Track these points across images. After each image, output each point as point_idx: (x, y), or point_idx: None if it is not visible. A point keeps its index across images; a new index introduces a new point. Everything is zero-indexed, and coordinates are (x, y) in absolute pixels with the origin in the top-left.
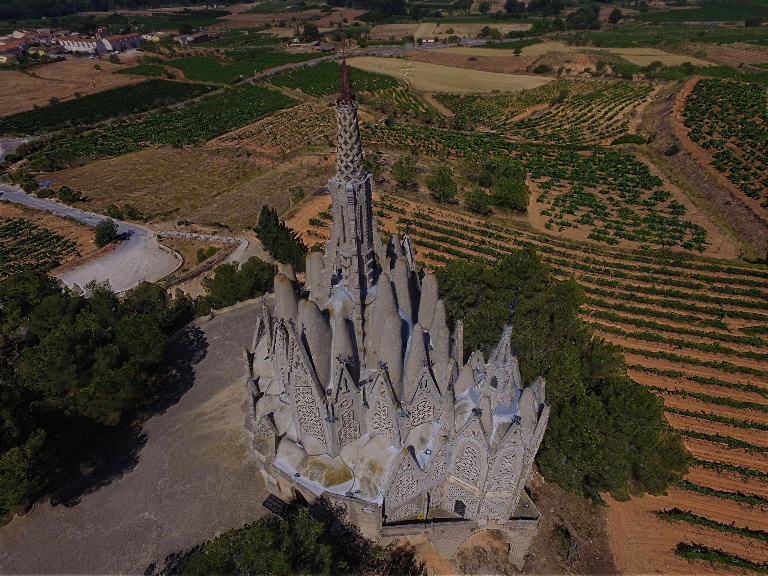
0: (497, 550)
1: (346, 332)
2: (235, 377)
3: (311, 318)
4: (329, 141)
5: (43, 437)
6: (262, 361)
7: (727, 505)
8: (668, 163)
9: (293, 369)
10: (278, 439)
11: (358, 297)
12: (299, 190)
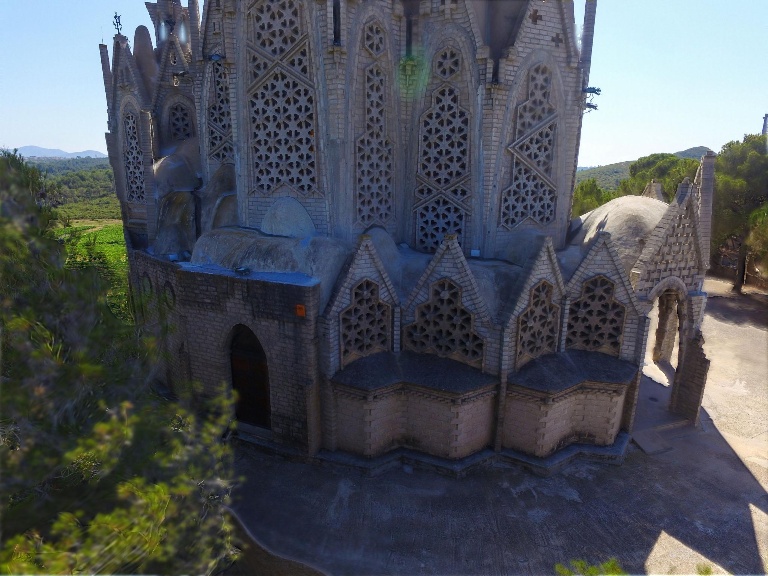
0: None
1: None
2: (760, 384)
3: None
4: None
5: (725, 183)
6: None
7: None
8: None
9: None
10: None
11: None
12: None
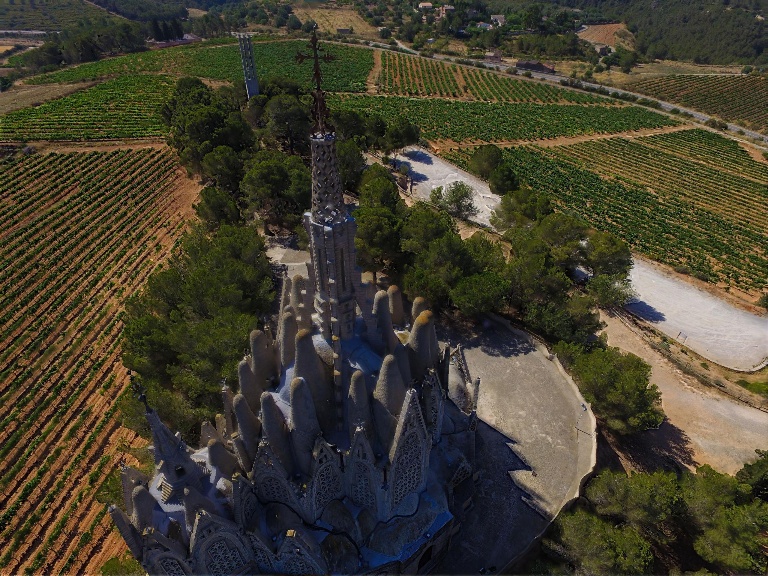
0: None
1: None
2: None
3: None
4: None
5: (375, 253)
6: None
7: None
8: None
9: None
10: None
11: None
12: None
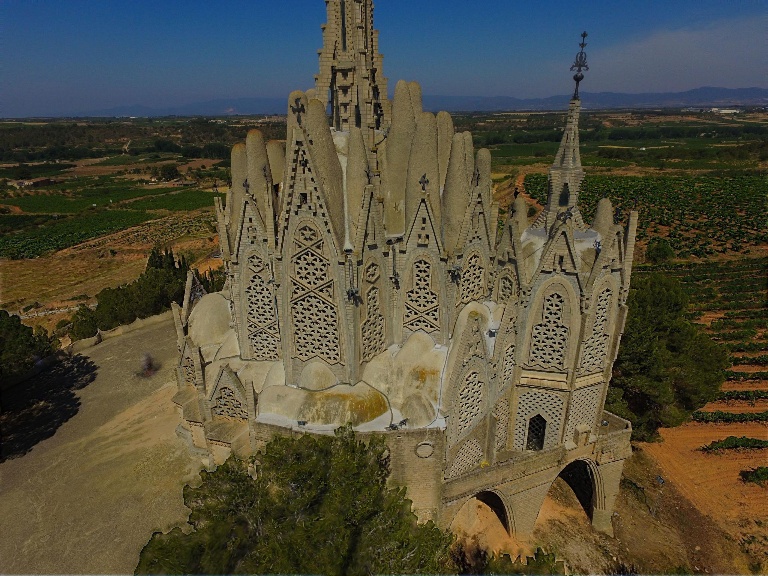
0: (575, 518)
1: (365, 153)
2: (148, 390)
3: (319, 122)
4: (212, 227)
5: None
6: (202, 323)
7: (753, 427)
8: (531, 222)
9: (291, 219)
10: (254, 394)
11: (369, 119)
12: (189, 254)
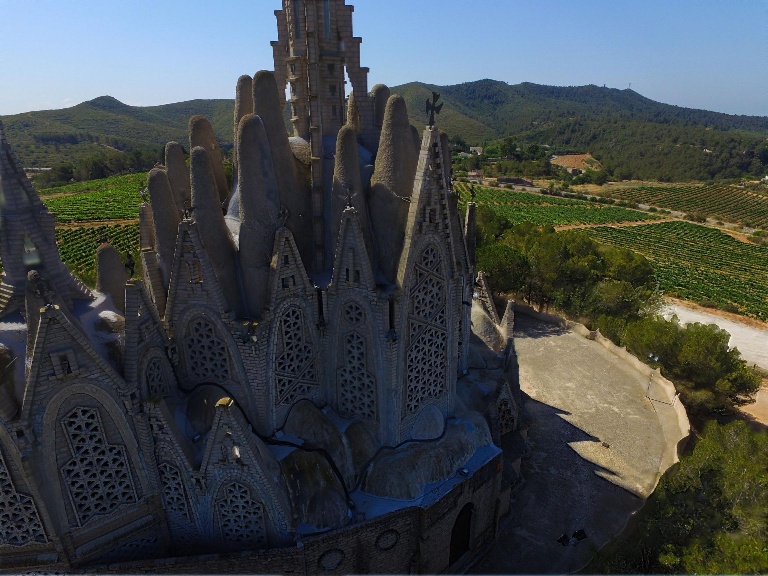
0: None
1: None
2: None
3: None
4: None
5: None
6: None
7: None
8: None
9: None
10: None
11: None
12: None
